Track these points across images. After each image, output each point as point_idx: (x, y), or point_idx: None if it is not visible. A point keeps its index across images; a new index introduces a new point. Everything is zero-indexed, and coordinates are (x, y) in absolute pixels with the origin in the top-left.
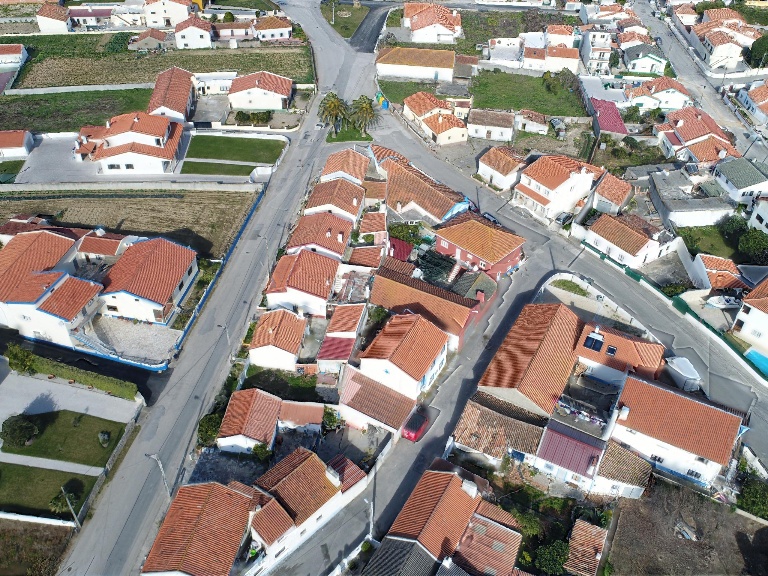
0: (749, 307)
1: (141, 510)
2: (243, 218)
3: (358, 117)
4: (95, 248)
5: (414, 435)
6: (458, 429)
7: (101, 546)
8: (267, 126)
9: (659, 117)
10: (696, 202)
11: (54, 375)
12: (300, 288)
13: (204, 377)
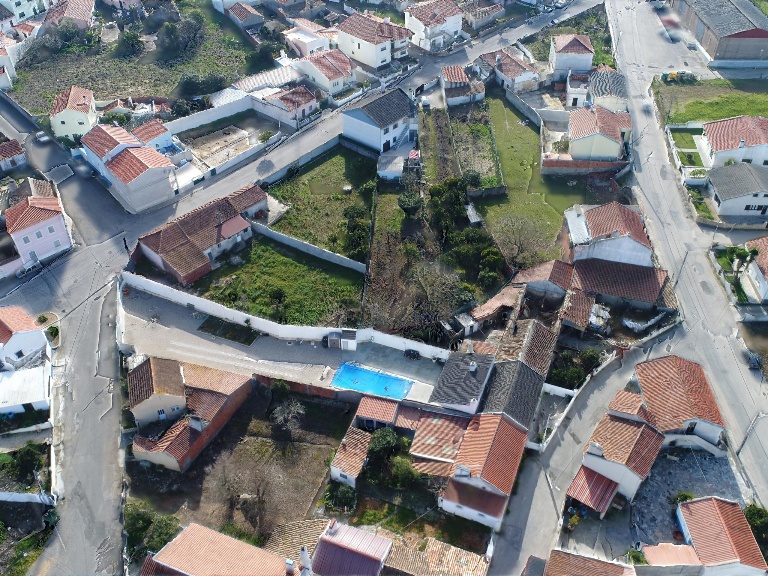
0: None
1: (753, 443)
2: None
3: None
4: None
5: None
6: (484, 569)
7: None
8: None
9: None
10: None
11: None
12: None
13: None
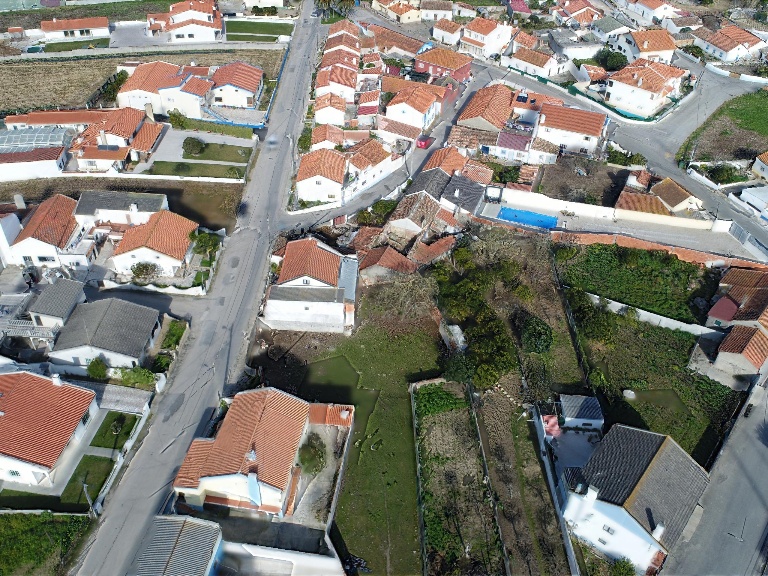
0: (612, 81)
1: (278, 177)
2: (281, 62)
3: (344, 4)
4: (193, 72)
5: (424, 143)
6: (449, 139)
7: (262, 189)
8: (277, 15)
9: (553, 5)
10: (580, 44)
11: (197, 129)
12: (338, 82)
13: (289, 129)
